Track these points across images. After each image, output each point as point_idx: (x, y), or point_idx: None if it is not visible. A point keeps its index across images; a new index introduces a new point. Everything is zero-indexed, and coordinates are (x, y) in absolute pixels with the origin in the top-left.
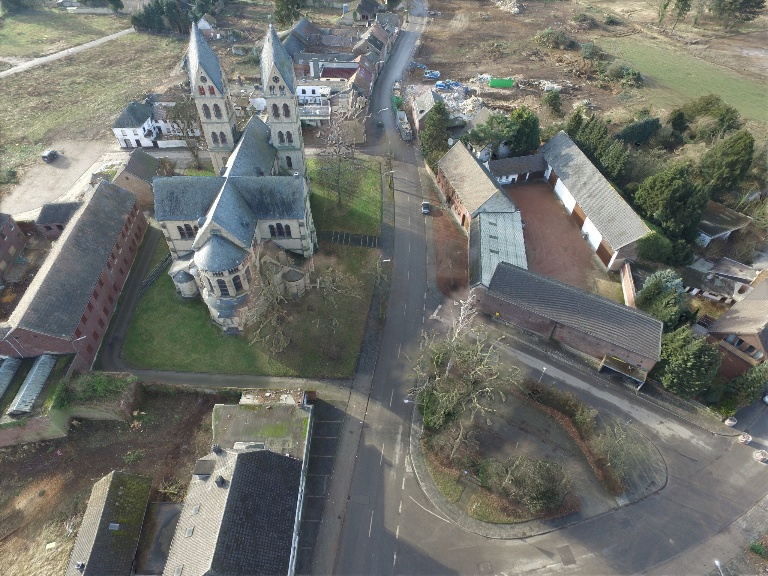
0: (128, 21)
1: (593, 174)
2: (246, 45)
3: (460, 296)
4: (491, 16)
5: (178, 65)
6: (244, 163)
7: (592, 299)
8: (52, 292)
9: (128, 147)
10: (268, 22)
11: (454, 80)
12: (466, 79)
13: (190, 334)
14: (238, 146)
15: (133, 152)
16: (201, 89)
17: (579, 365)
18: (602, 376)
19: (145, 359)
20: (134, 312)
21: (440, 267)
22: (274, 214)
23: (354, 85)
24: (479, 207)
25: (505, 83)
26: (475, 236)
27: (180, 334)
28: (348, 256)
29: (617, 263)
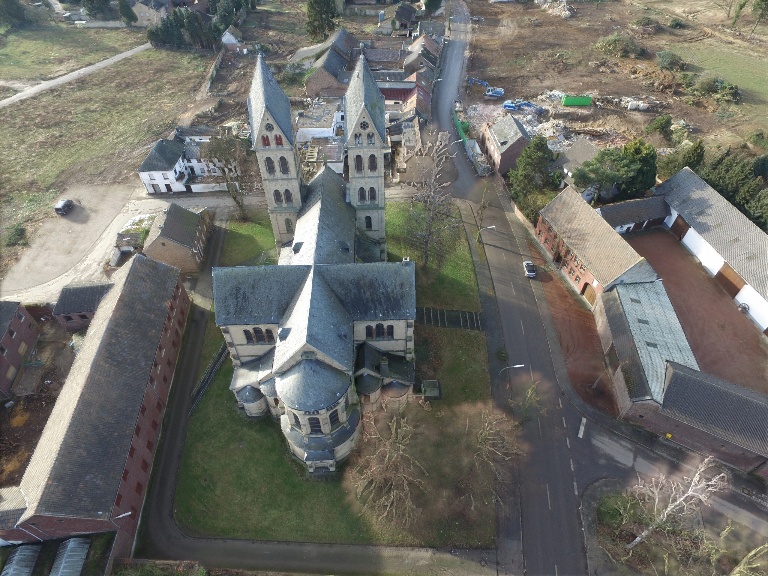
0: (143, 35)
1: (747, 228)
2: (278, 61)
3: (607, 403)
4: (541, 21)
5: (204, 86)
6: (327, 239)
7: None
8: (81, 442)
9: (156, 192)
10: (297, 33)
11: (520, 98)
12: (533, 96)
13: (264, 477)
14: (313, 211)
15: (169, 209)
16: (265, 139)
17: None
18: None
19: (207, 520)
20: (185, 440)
21: (569, 358)
22: (375, 313)
23: (417, 110)
24: (616, 278)
25: (582, 101)
26: (618, 320)
27: (250, 477)
28: (450, 344)
29: None
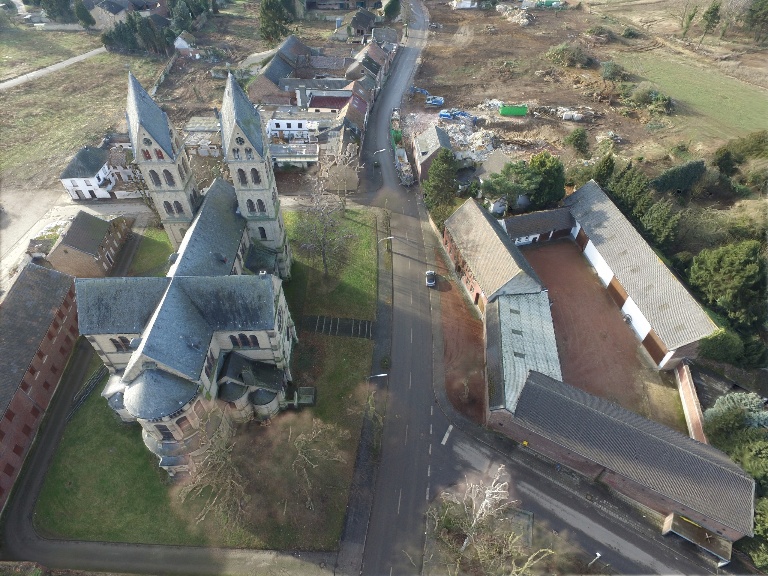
0: None
1: (635, 241)
2: None
3: (476, 411)
4: (498, 28)
5: (150, 91)
6: (199, 250)
7: (654, 440)
8: None
9: (81, 199)
10: (254, 38)
11: (460, 107)
12: (473, 105)
13: (127, 481)
14: (194, 223)
15: (76, 216)
16: (146, 153)
17: (636, 523)
18: (668, 542)
19: (64, 523)
20: (58, 444)
21: (450, 366)
22: (235, 324)
23: (346, 120)
24: (497, 290)
25: (518, 111)
26: (494, 330)
27: (114, 481)
28: (335, 352)
29: (672, 362)
